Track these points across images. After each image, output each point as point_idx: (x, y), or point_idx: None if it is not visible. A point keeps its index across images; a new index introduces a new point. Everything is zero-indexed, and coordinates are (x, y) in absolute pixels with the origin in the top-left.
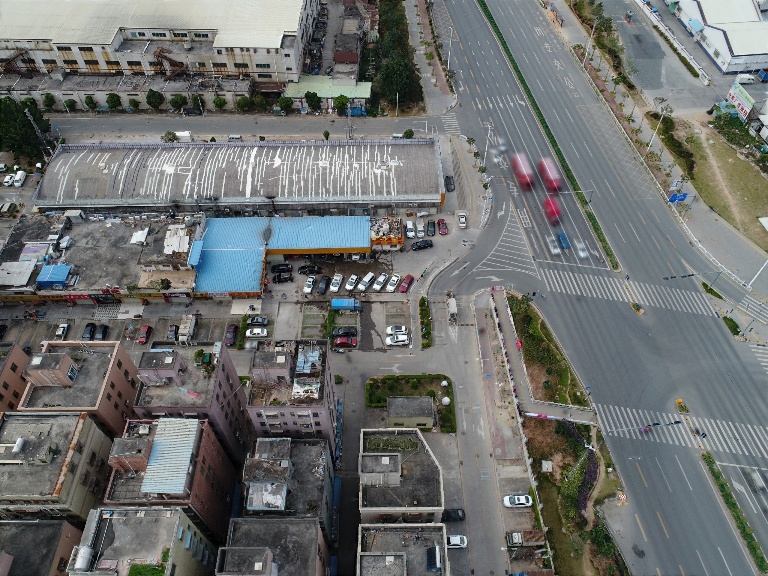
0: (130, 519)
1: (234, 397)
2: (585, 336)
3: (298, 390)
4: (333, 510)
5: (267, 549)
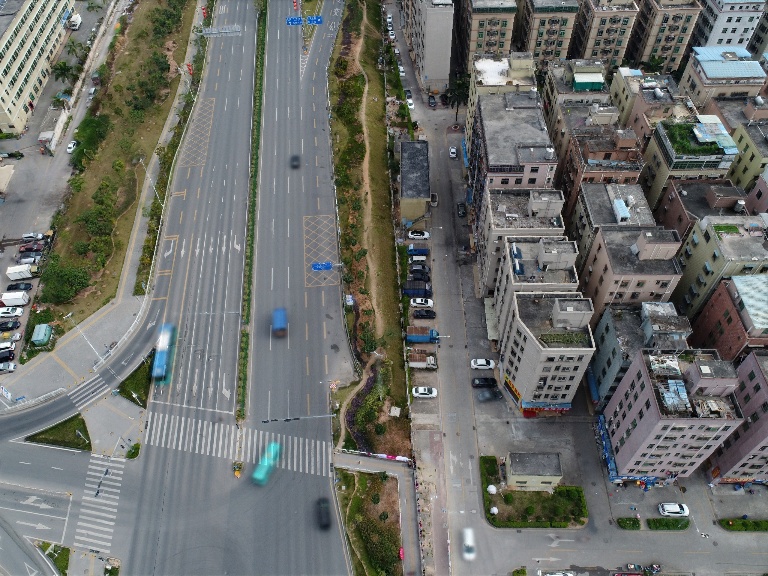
0: (761, 257)
1: (737, 431)
2: (311, 573)
3: (672, 363)
4: (592, 372)
5: (647, 242)
